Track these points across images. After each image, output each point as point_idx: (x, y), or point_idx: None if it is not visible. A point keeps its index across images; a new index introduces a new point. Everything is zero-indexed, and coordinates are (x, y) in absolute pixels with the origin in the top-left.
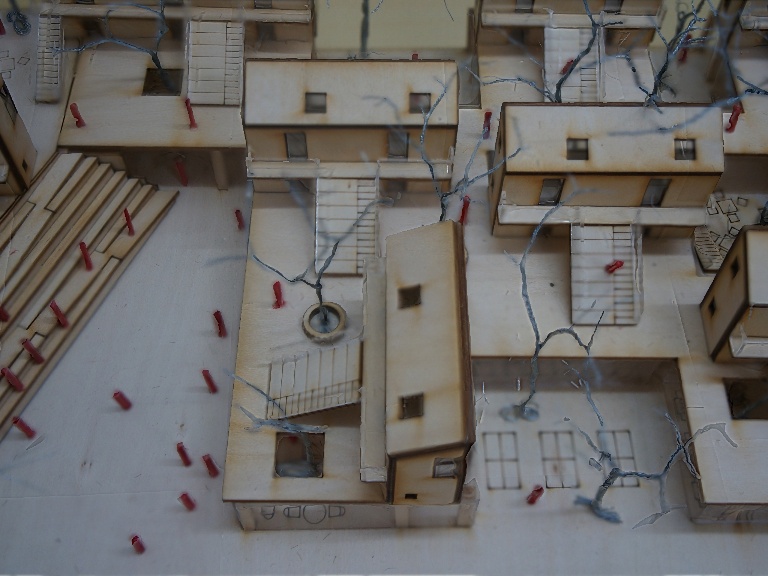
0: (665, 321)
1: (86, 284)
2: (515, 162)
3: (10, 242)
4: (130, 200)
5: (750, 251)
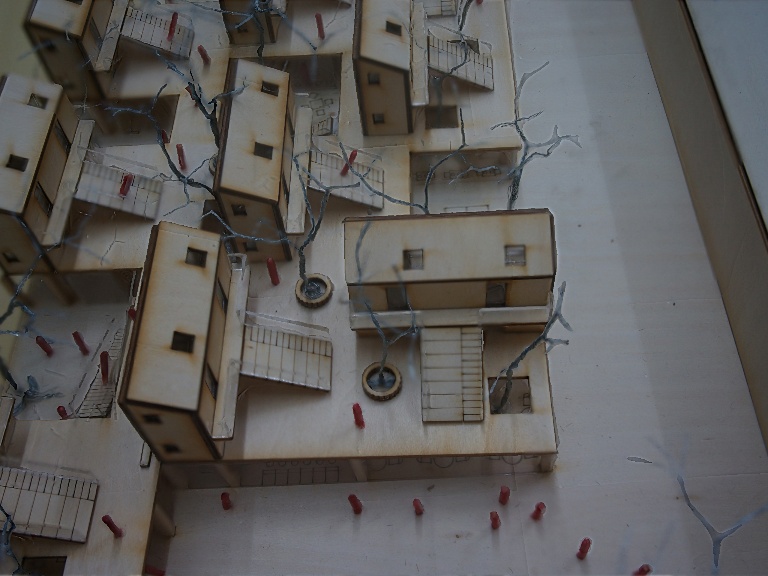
0: None
1: None
2: (271, 193)
3: None
4: None
5: (375, 58)
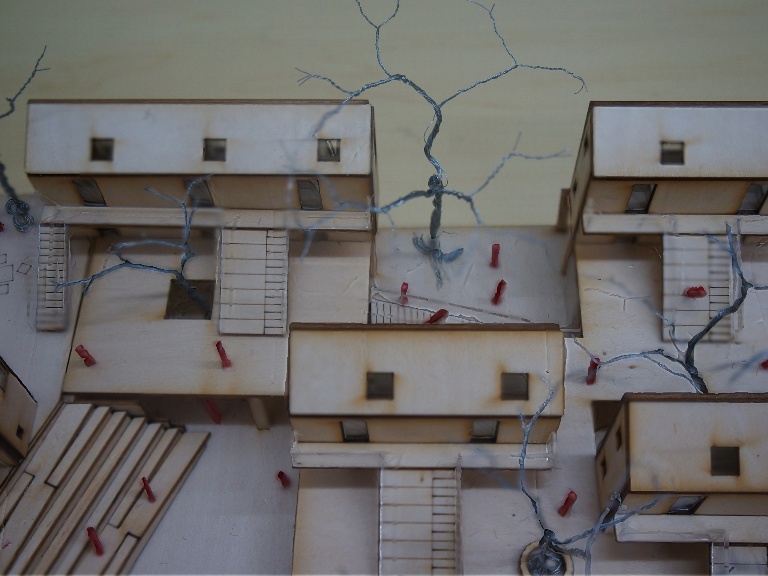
0: None
1: None
2: (642, 479)
3: (2, 530)
4: (151, 451)
5: None
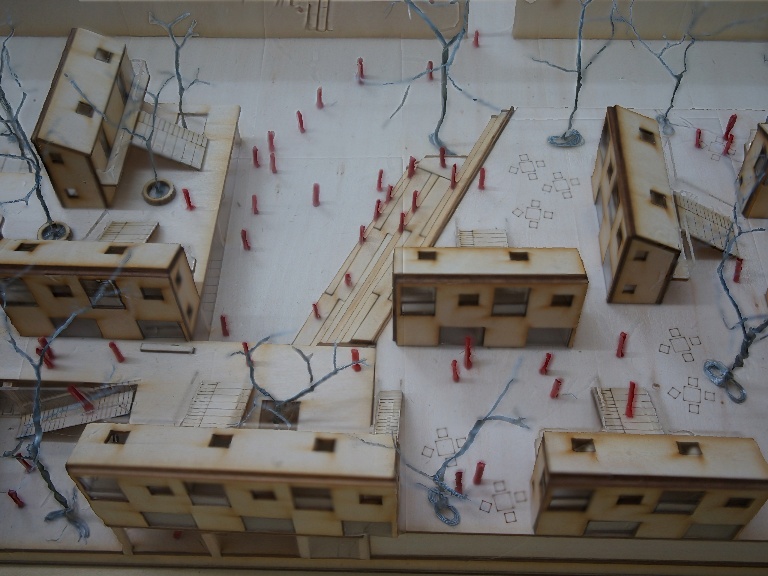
0: None
1: (349, 270)
2: None
3: None
4: None
5: None
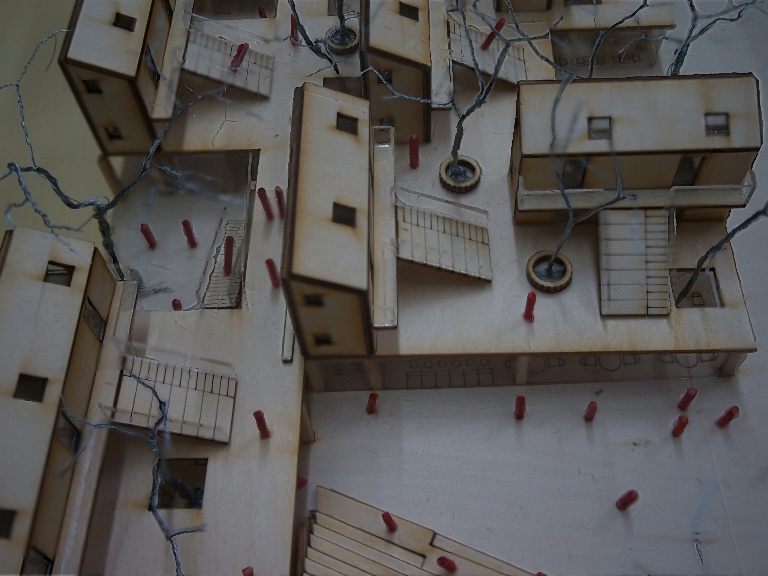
0: (515, 33)
1: (478, 567)
2: (422, 57)
3: None
4: None
5: None
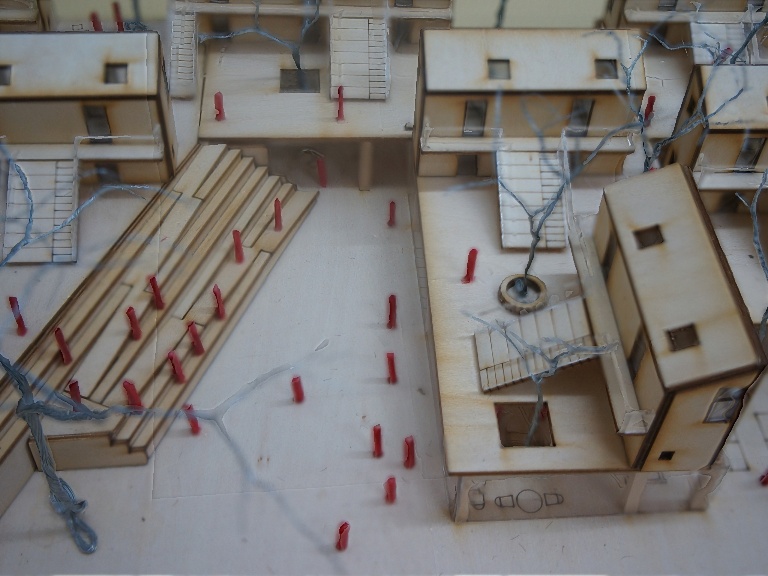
0: None
1: (239, 276)
2: (717, 120)
3: (159, 229)
4: (272, 197)
5: None
